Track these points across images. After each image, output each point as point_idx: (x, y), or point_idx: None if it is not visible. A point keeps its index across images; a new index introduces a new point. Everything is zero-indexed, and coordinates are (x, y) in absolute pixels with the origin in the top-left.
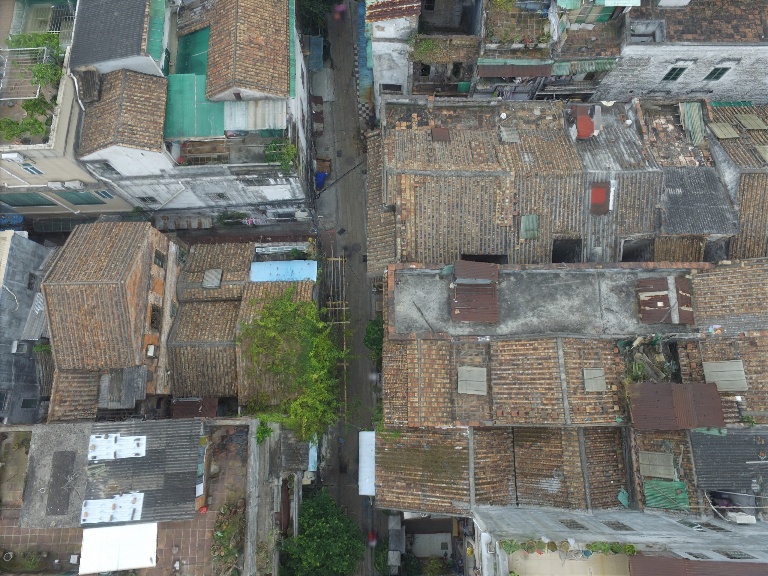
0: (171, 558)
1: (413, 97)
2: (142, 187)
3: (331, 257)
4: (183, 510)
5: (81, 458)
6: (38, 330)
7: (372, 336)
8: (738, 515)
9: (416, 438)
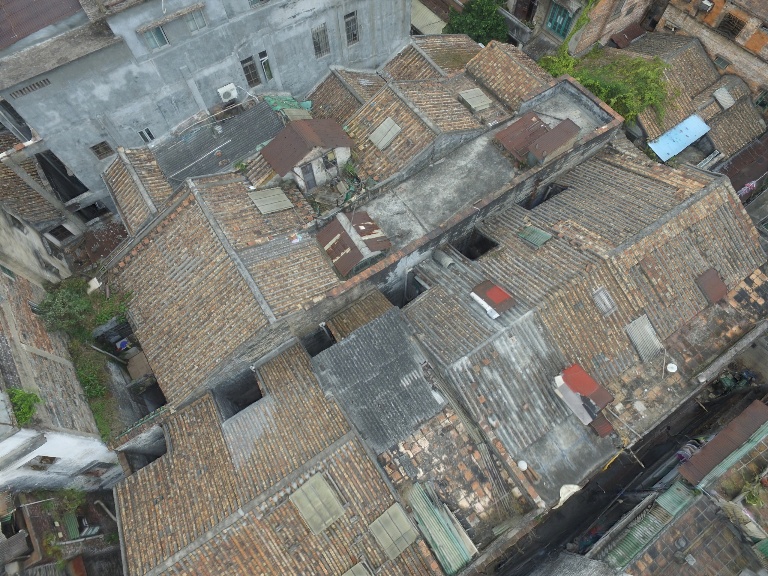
0: None
1: None
2: None
3: None
4: None
5: None
6: None
7: None
8: (233, 89)
9: None
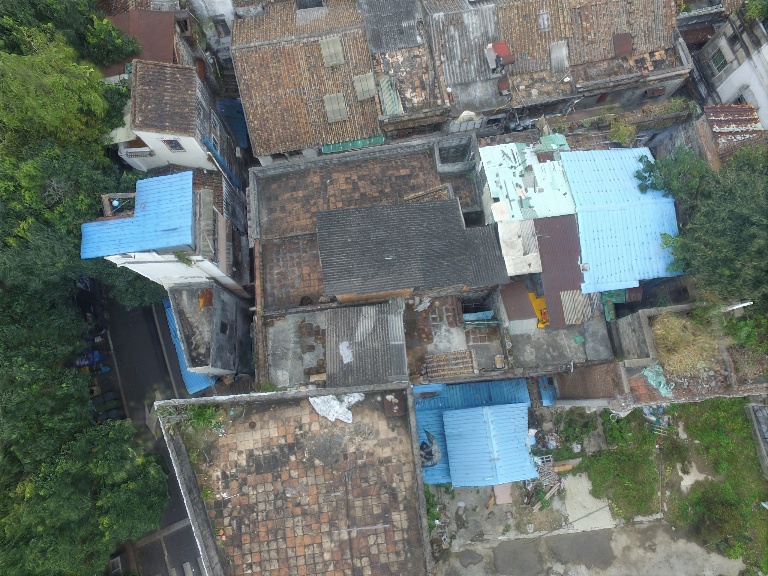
0: None
1: (663, 71)
2: None
3: None
4: None
5: None
6: None
7: None
8: None
9: None
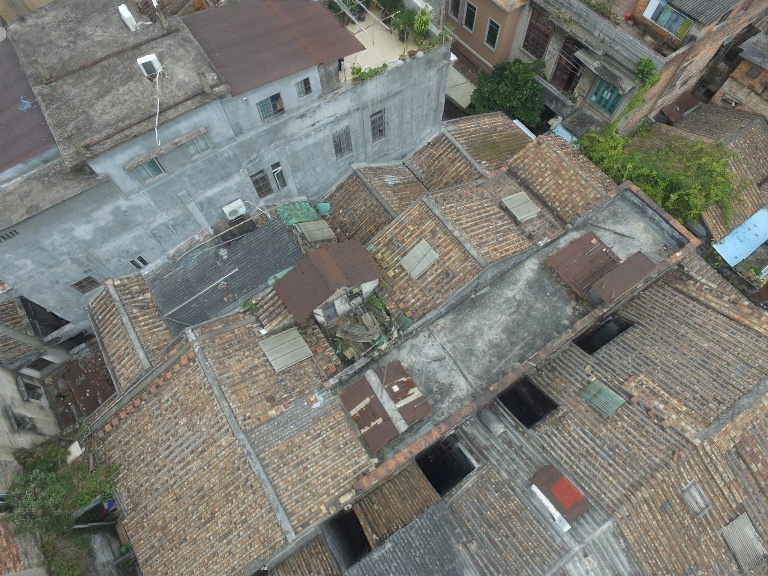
0: None
1: None
2: None
3: None
4: None
5: None
6: None
7: None
8: (240, 206)
9: None
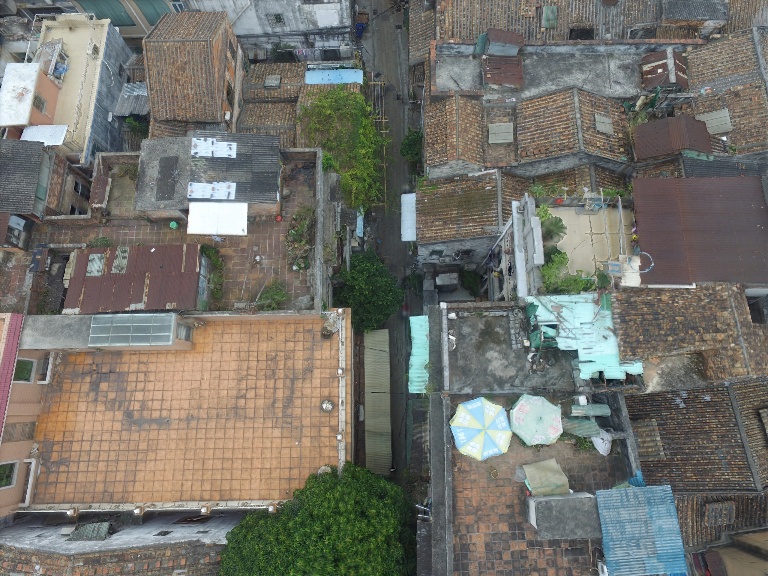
0: (252, 254)
1: None
2: (213, 1)
3: (372, 81)
4: (268, 197)
5: (183, 161)
6: (128, 109)
7: (409, 137)
8: None
9: (452, 187)
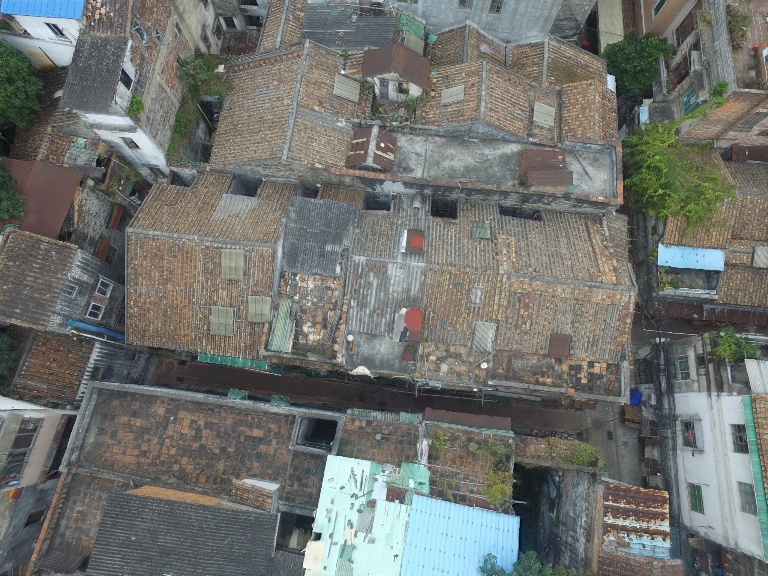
0: None
1: (592, 396)
2: None
3: None
4: None
5: None
6: None
7: None
8: None
9: None
